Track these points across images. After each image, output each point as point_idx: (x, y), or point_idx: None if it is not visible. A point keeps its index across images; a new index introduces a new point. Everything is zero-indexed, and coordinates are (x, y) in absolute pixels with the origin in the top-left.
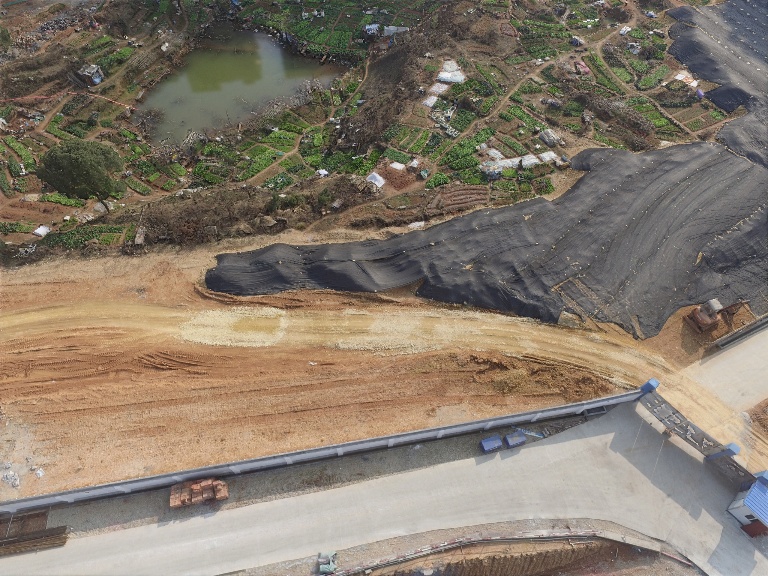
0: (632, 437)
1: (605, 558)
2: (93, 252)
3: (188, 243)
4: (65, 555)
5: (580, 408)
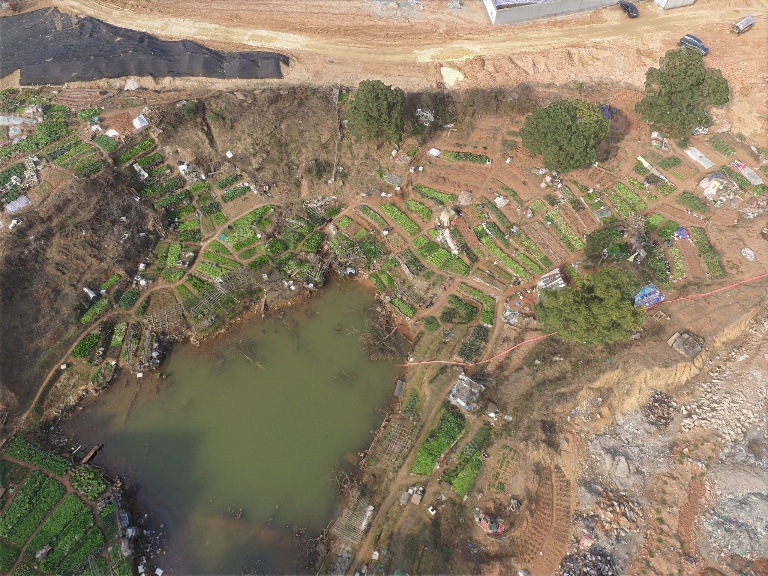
0: None
1: None
2: None
3: None
4: None
5: None
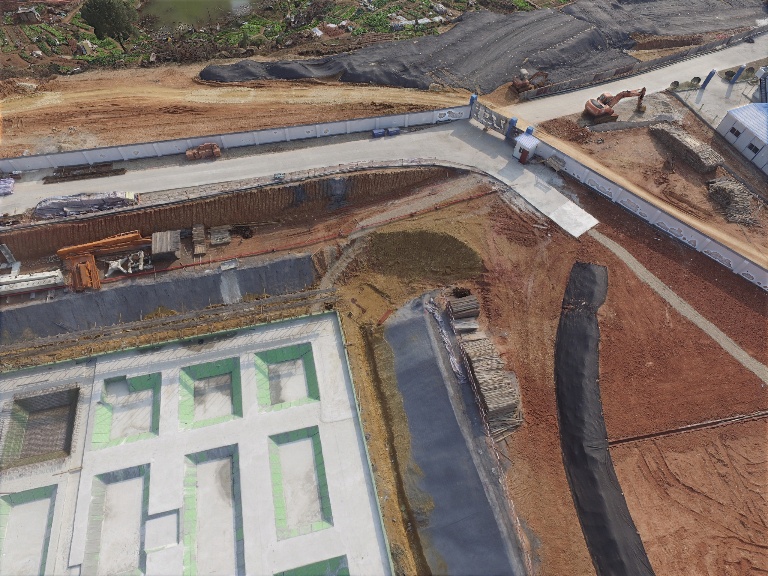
0: (464, 131)
1: (441, 178)
2: (121, 66)
3: (186, 62)
4: (126, 177)
5: (433, 115)
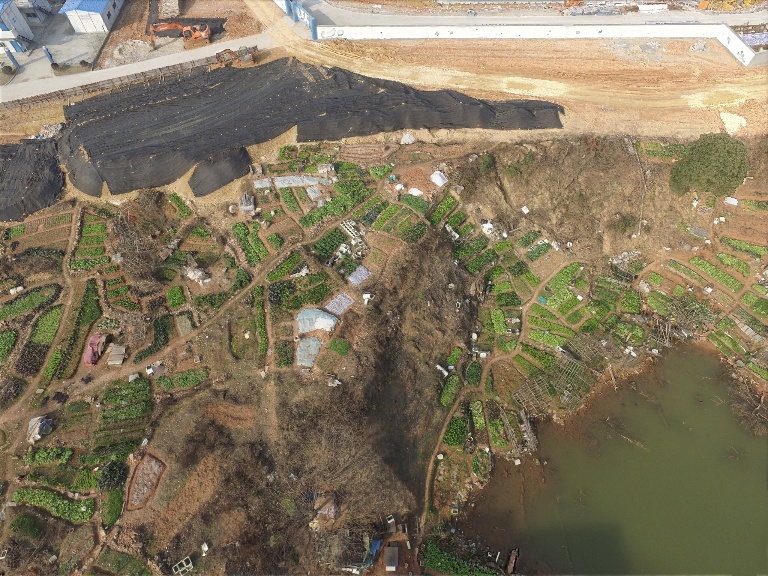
0: None
1: None
2: None
3: None
4: None
5: None
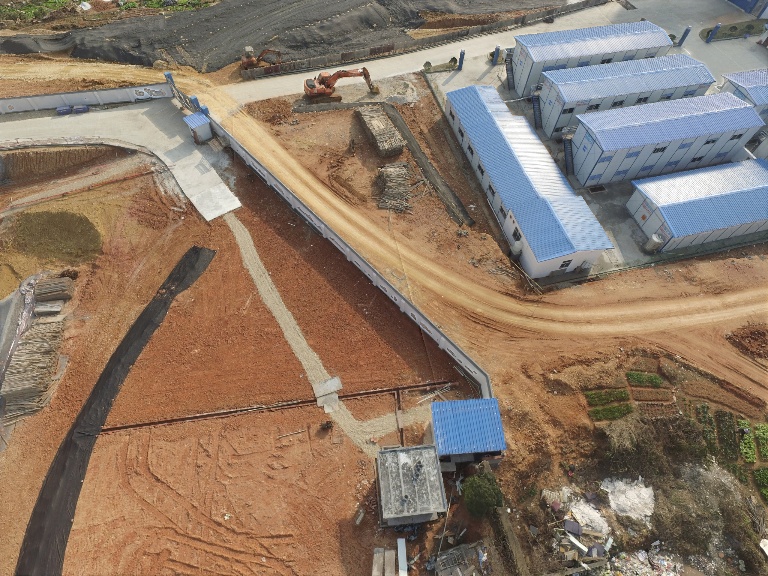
0: (159, 110)
1: (110, 158)
2: None
3: None
4: None
5: (127, 93)
